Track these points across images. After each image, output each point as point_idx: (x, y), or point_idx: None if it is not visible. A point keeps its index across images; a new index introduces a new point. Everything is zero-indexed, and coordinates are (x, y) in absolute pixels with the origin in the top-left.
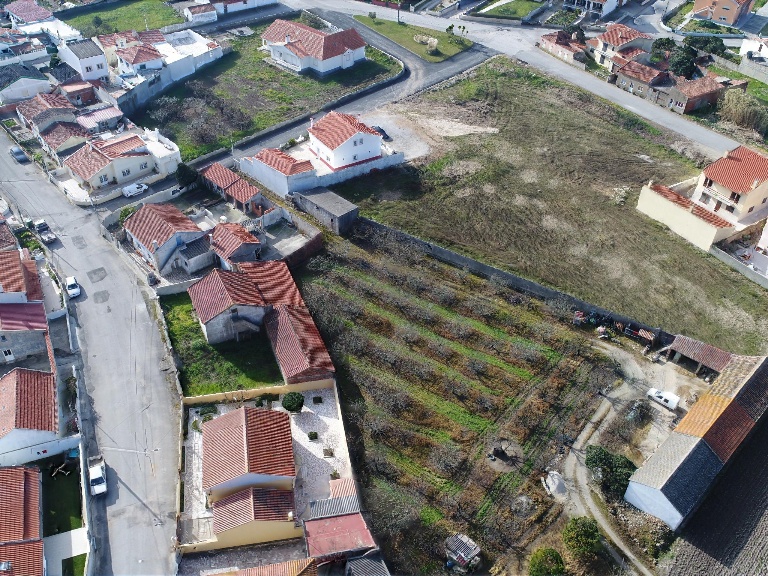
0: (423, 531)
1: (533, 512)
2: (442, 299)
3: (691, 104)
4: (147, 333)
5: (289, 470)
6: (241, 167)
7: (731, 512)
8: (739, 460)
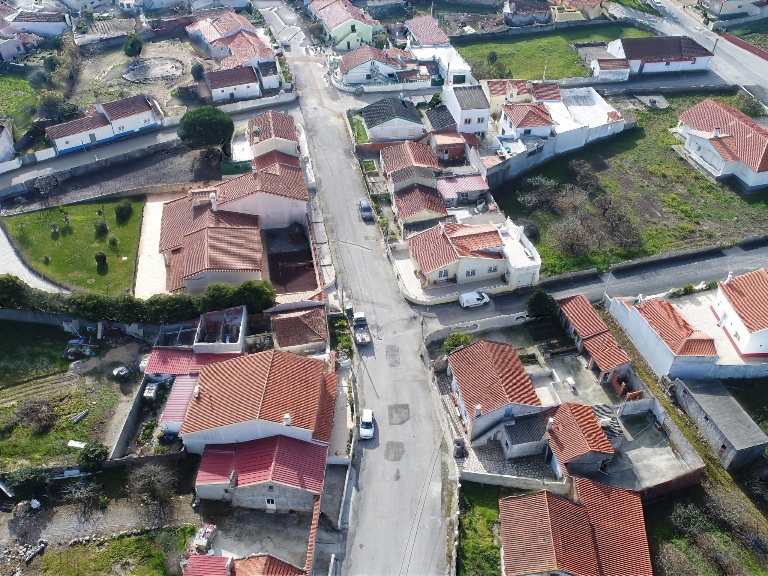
0: None
1: None
2: None
3: None
4: (431, 536)
5: None
6: (611, 307)
7: None
8: None
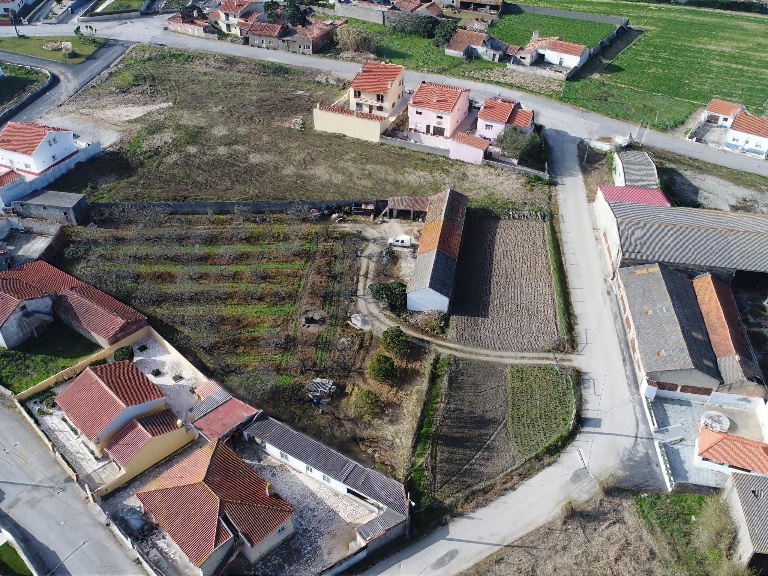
0: (285, 392)
1: (354, 344)
2: (202, 240)
3: (315, 45)
4: None
5: (158, 394)
6: None
7: (473, 288)
8: (463, 258)
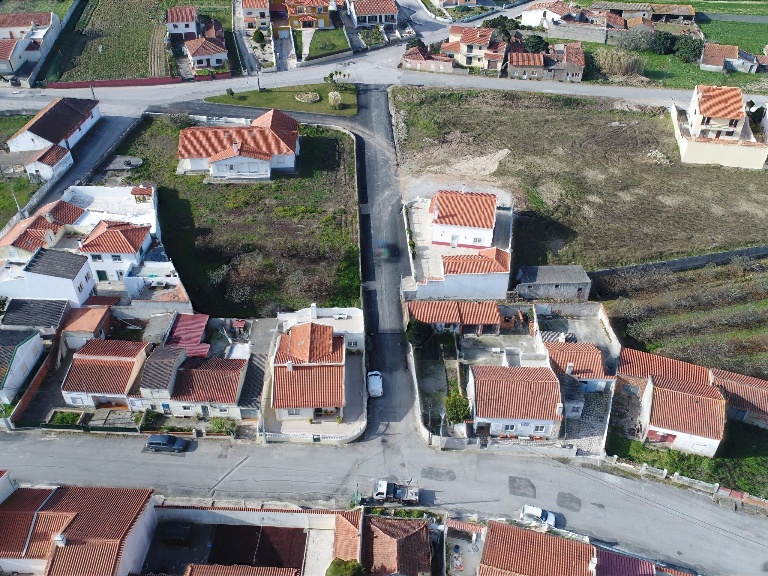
0: None
1: None
2: (732, 298)
3: (584, 71)
4: (663, 494)
5: None
6: (419, 295)
7: None
8: None
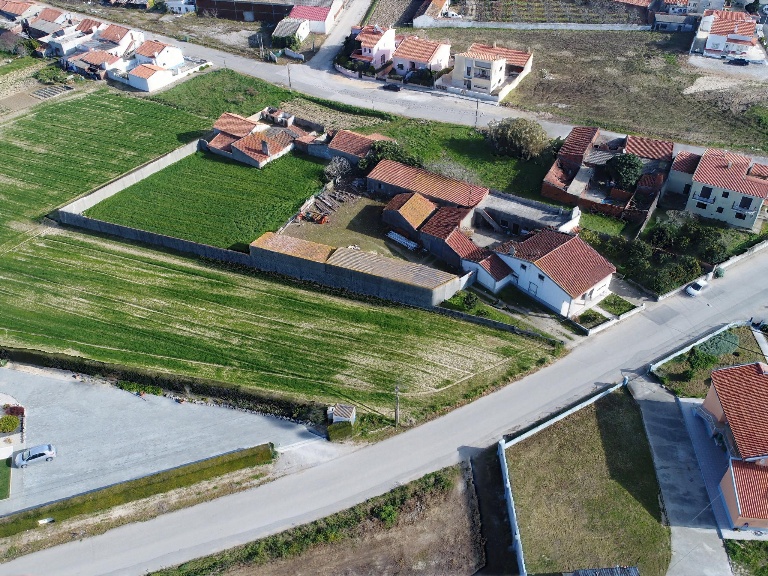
0: None
1: None
2: None
3: None
4: None
5: None
6: None
7: (418, 5)
8: None
